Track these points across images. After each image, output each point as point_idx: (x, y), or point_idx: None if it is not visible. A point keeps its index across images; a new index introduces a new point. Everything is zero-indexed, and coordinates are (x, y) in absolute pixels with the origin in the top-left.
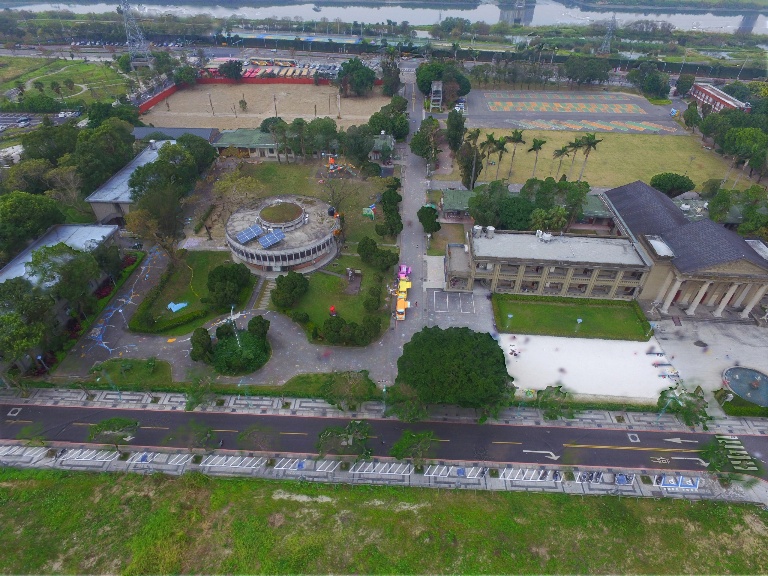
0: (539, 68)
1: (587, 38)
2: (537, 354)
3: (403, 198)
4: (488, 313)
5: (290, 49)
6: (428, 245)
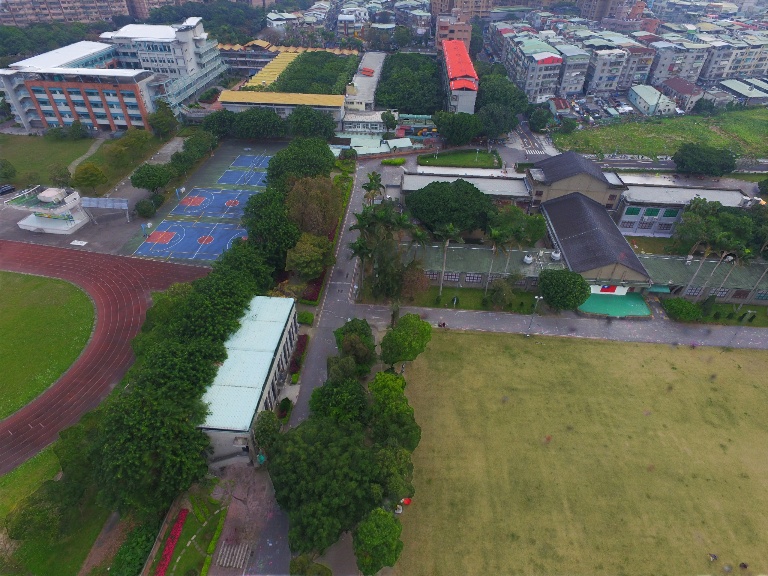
0: None
1: None
2: None
3: None
4: None
5: None
6: None
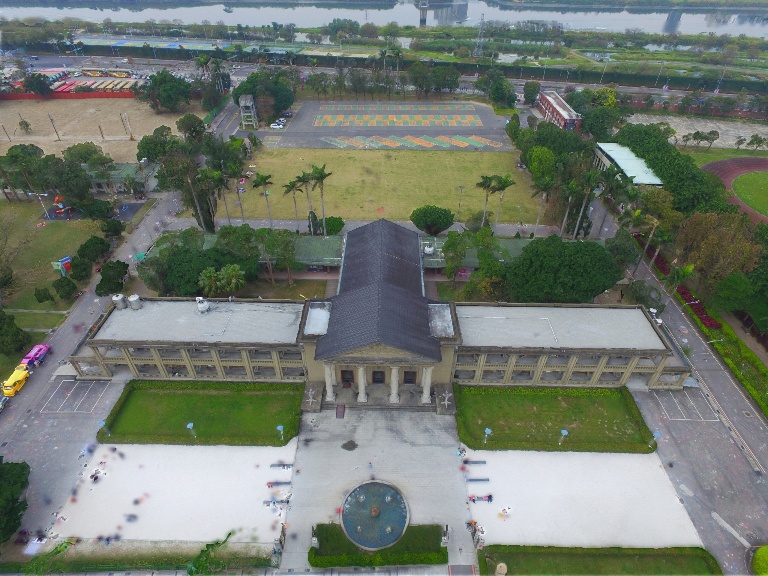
0: (387, 76)
1: (461, 41)
2: (127, 475)
3: (126, 244)
4: (108, 411)
5: (127, 58)
6: (103, 311)
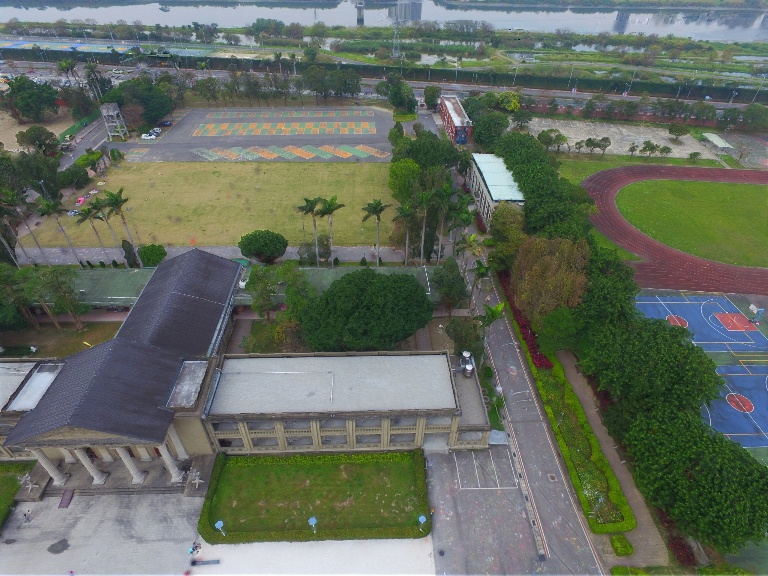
0: (285, 80)
1: (378, 42)
2: None
3: None
4: None
5: (7, 61)
6: None
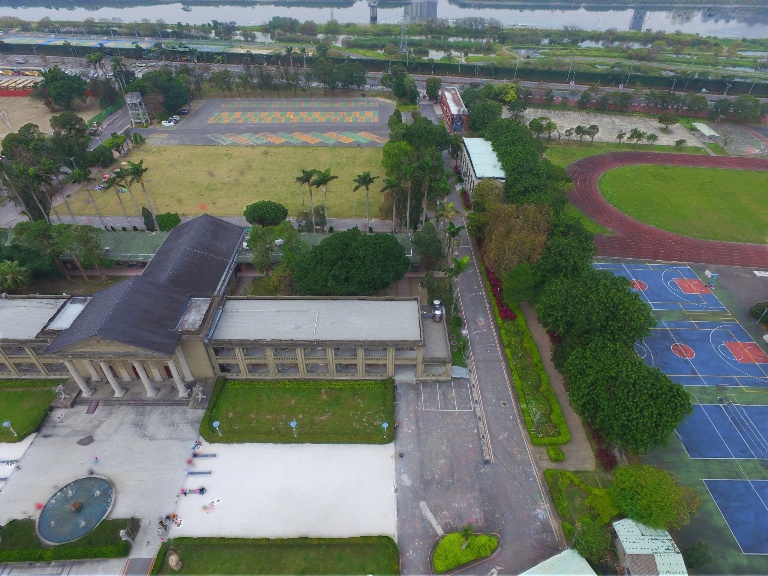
0: (296, 73)
1: (387, 38)
2: None
3: None
4: None
5: (41, 56)
6: None
